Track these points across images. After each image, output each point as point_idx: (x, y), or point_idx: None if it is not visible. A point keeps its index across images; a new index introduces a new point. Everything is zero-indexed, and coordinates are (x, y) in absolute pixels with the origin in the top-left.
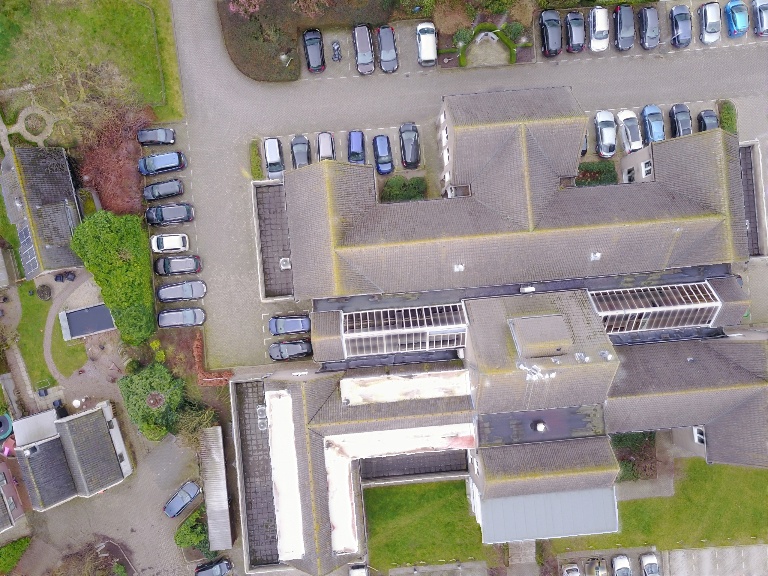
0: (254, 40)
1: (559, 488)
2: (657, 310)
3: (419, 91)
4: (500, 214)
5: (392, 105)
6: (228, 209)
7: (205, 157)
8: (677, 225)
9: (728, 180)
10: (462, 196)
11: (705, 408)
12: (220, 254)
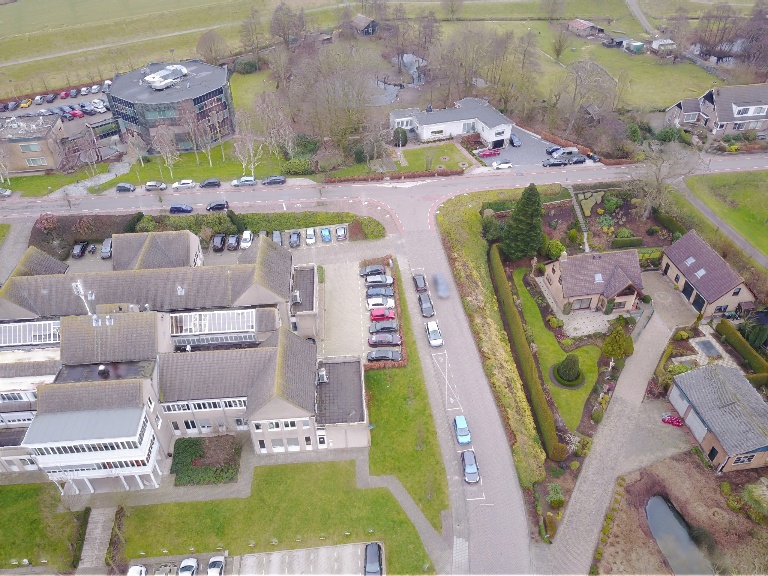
0: (46, 243)
1: (98, 403)
2: (211, 313)
3: None
4: None
5: None
6: None
7: None
8: (227, 268)
9: (265, 254)
10: None
11: (240, 373)
12: None
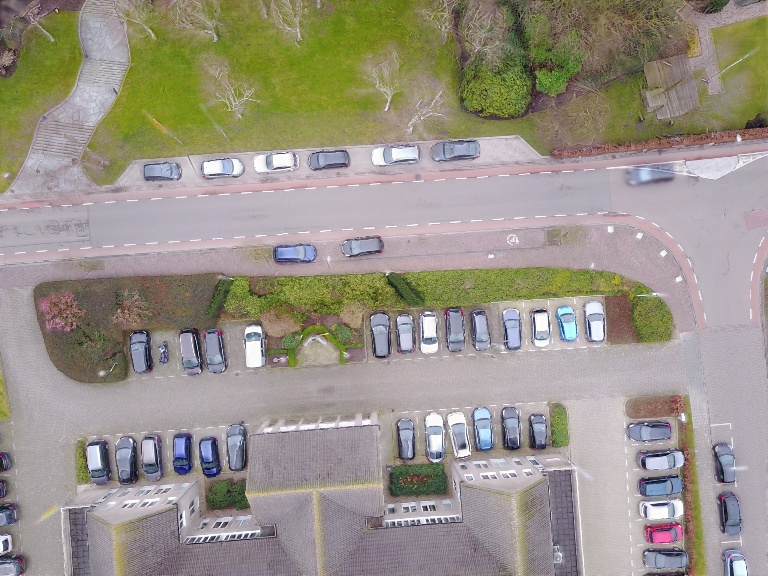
0: (77, 346)
1: None
2: None
3: (248, 390)
4: (297, 569)
5: (221, 404)
6: (53, 508)
7: (30, 456)
8: None
9: (524, 543)
10: (267, 536)
11: None
12: (44, 554)
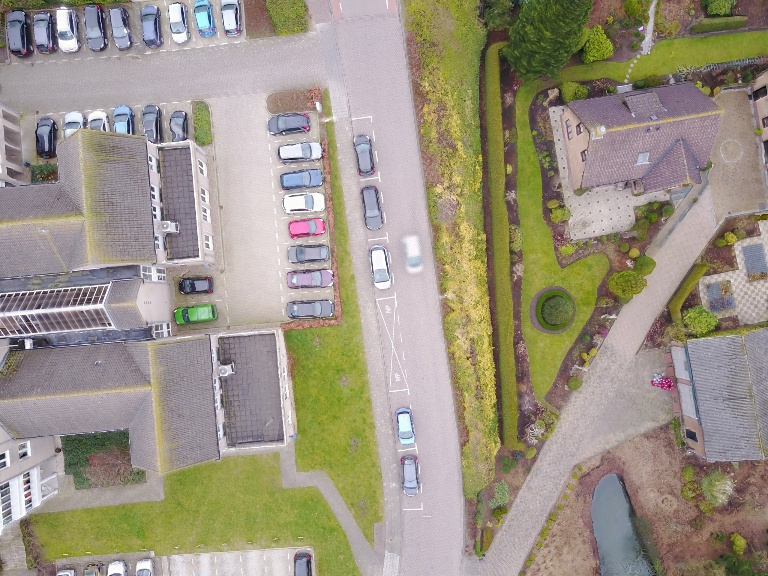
0: None
1: None
2: (38, 312)
3: None
4: None
5: None
6: None
7: None
8: (38, 226)
9: (96, 181)
10: None
11: (109, 412)
12: None
